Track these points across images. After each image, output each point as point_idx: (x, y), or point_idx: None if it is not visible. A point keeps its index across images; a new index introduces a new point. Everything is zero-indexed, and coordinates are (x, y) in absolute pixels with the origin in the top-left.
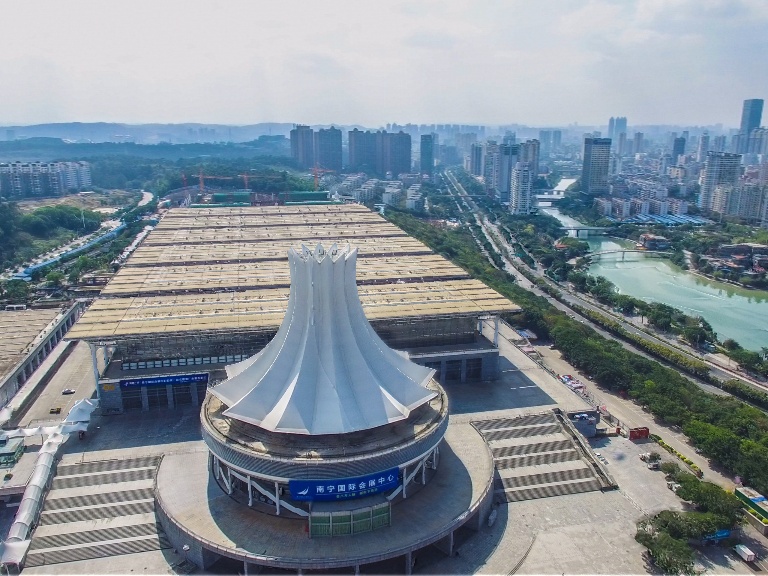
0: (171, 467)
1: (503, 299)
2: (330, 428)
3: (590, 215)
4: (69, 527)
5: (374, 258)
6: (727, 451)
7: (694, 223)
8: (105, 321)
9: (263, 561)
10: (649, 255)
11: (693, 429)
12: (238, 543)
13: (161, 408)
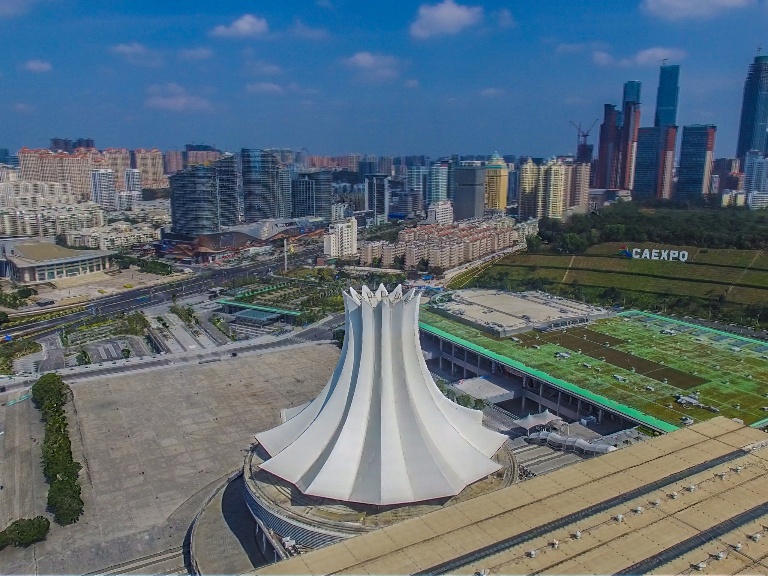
0: None
1: None
2: None
3: None
4: (534, 453)
5: None
6: None
7: None
8: (763, 447)
9: None
10: None
11: None
12: None
13: None
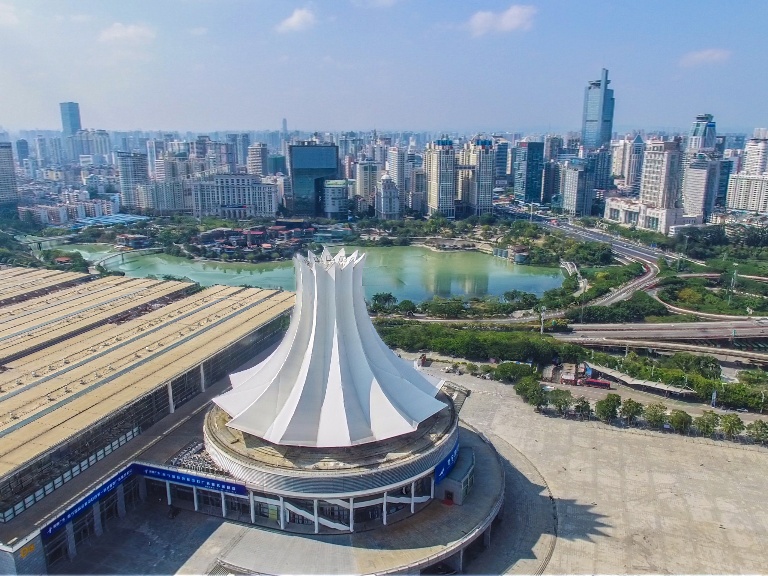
0: (255, 560)
1: (283, 292)
2: (431, 409)
3: (26, 226)
4: None
5: (53, 294)
6: (479, 347)
7: (142, 220)
8: None
9: (474, 537)
10: (144, 253)
11: (440, 345)
12: (440, 543)
13: (90, 541)
